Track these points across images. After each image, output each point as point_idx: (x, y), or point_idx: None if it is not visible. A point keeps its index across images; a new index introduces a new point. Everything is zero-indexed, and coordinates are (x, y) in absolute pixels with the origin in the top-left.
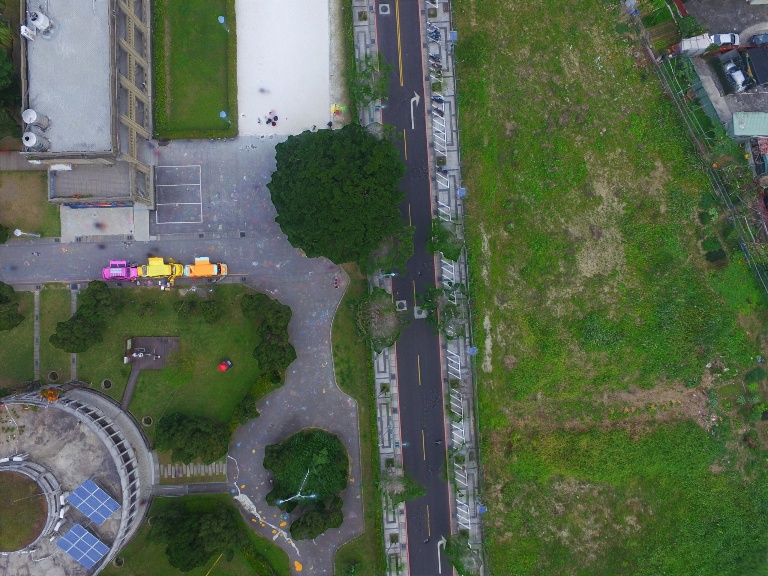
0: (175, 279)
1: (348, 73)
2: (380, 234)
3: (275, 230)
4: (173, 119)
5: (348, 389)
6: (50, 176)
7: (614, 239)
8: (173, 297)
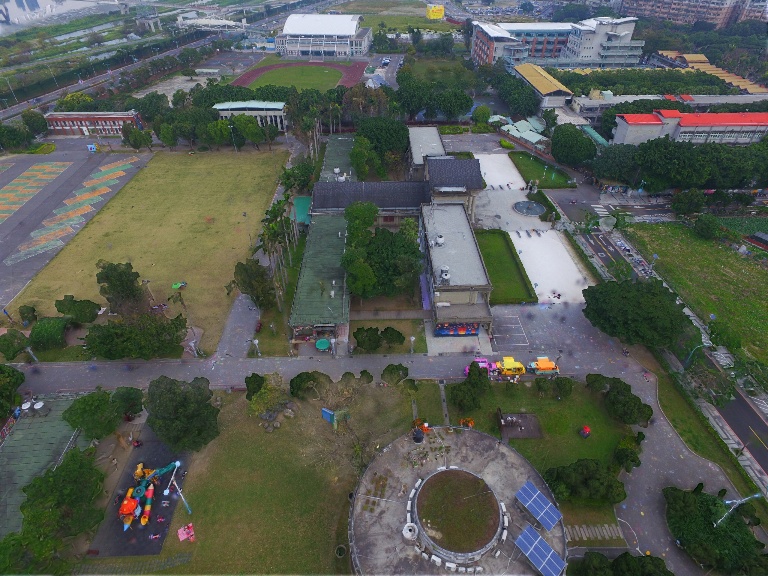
0: (520, 376)
1: (596, 276)
2: (681, 324)
3: (584, 348)
4: (493, 296)
5: (704, 454)
6: None
7: None
8: (521, 388)
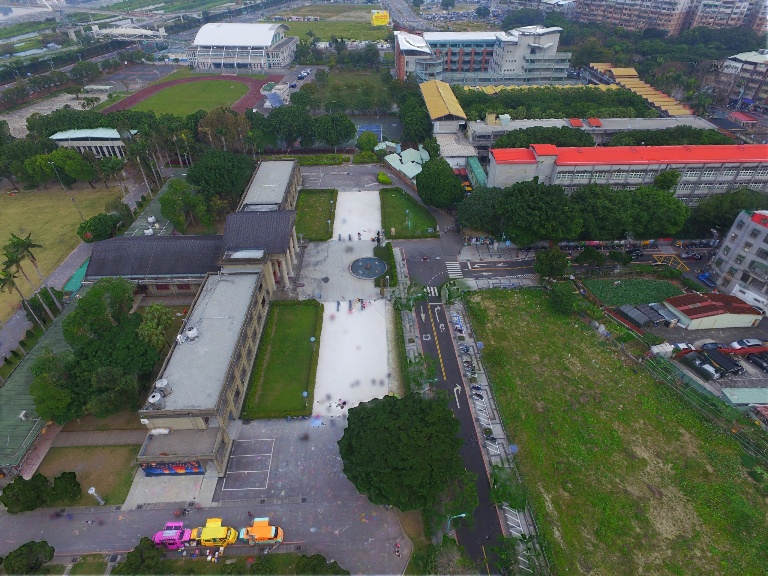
0: (225, 548)
1: (403, 372)
2: (445, 475)
3: (336, 495)
4: (259, 405)
5: None
6: (148, 438)
7: (677, 498)
8: (218, 570)
